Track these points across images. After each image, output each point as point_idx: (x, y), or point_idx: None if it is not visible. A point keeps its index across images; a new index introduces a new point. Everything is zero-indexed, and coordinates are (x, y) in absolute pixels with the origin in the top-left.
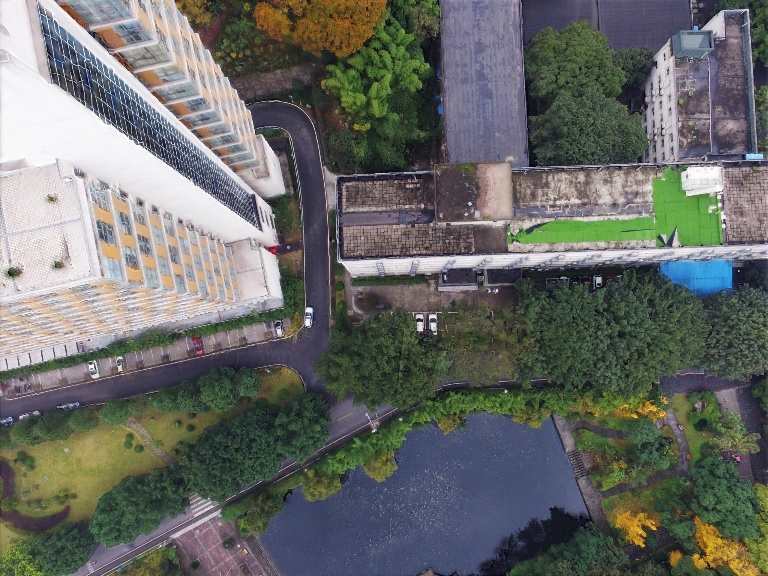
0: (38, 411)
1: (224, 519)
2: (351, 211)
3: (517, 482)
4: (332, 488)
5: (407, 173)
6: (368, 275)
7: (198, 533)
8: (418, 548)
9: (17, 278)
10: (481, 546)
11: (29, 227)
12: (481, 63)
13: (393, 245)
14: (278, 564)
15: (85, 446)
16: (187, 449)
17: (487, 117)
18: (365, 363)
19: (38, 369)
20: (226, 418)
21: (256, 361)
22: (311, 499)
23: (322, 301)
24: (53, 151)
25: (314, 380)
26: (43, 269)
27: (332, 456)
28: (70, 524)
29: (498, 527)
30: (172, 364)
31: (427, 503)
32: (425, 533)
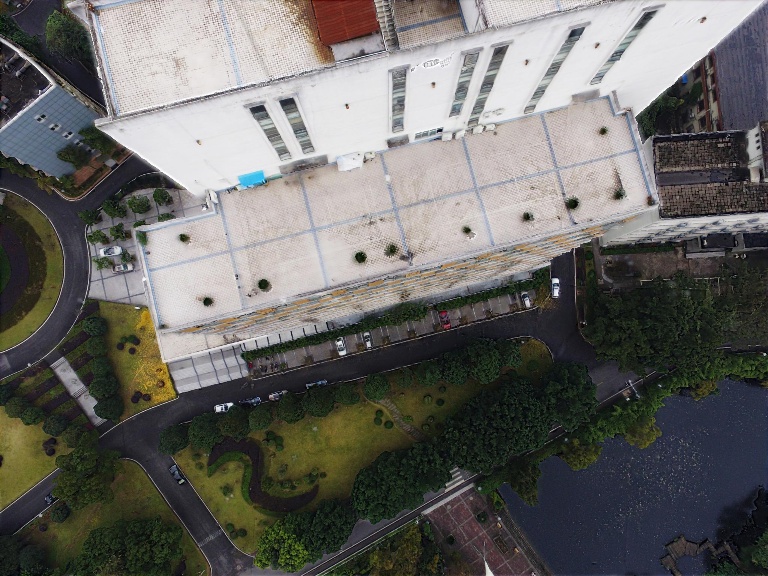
0: (286, 390)
1: (482, 492)
2: (664, 171)
3: (763, 447)
4: (596, 456)
5: (721, 132)
6: (616, 244)
7: (450, 508)
8: (668, 516)
9: (572, 211)
10: (731, 512)
11: (580, 160)
12: (749, 28)
13: (708, 203)
14: (529, 537)
15: (334, 424)
16: (453, 421)
17: (758, 81)
18: (660, 325)
19: (288, 347)
20: (487, 389)
21: (502, 333)
22: (578, 468)
23: (567, 271)
24: (627, 81)
25: (561, 351)
26: (598, 201)
27: (592, 425)
28: (330, 502)
29: (746, 492)
30: (418, 339)
31: (675, 471)
32: (675, 501)
